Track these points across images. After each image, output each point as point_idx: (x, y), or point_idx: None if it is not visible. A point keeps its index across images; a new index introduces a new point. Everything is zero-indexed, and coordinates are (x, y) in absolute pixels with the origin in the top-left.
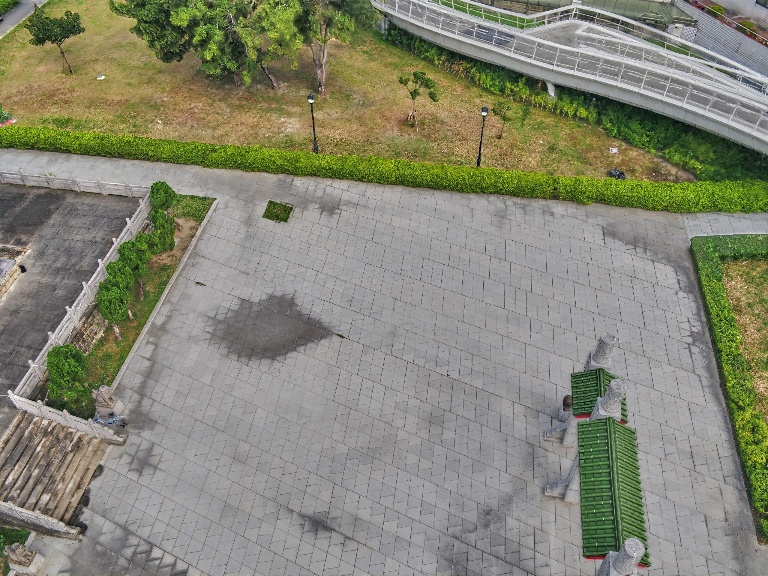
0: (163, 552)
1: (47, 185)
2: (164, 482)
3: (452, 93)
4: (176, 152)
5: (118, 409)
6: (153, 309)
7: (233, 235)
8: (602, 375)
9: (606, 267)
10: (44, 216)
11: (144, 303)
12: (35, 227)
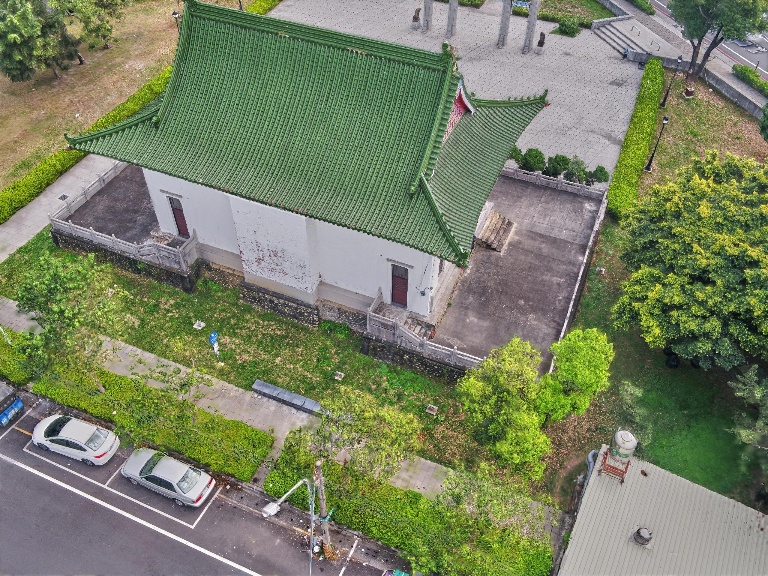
0: None
1: None
2: None
3: (156, 6)
4: (138, 103)
5: None
6: None
7: None
8: None
9: (337, 2)
10: None
11: None
12: None
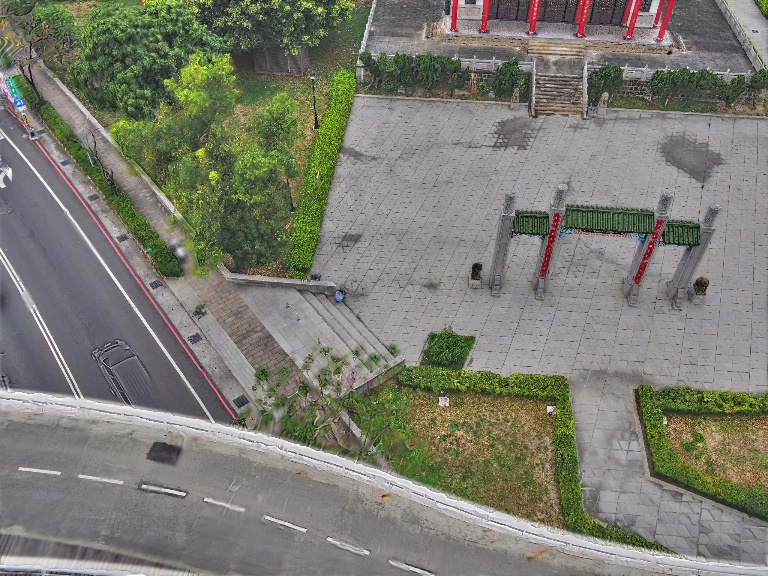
0: (533, 141)
1: (742, 43)
2: (568, 135)
3: None
4: None
5: (602, 111)
6: (677, 111)
7: (765, 132)
8: (694, 225)
9: None
10: (716, 50)
11: (679, 107)
12: (705, 50)
